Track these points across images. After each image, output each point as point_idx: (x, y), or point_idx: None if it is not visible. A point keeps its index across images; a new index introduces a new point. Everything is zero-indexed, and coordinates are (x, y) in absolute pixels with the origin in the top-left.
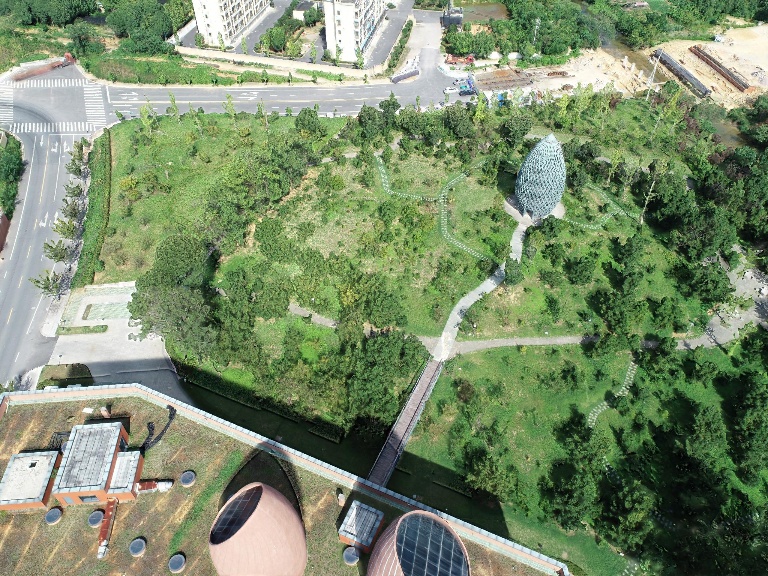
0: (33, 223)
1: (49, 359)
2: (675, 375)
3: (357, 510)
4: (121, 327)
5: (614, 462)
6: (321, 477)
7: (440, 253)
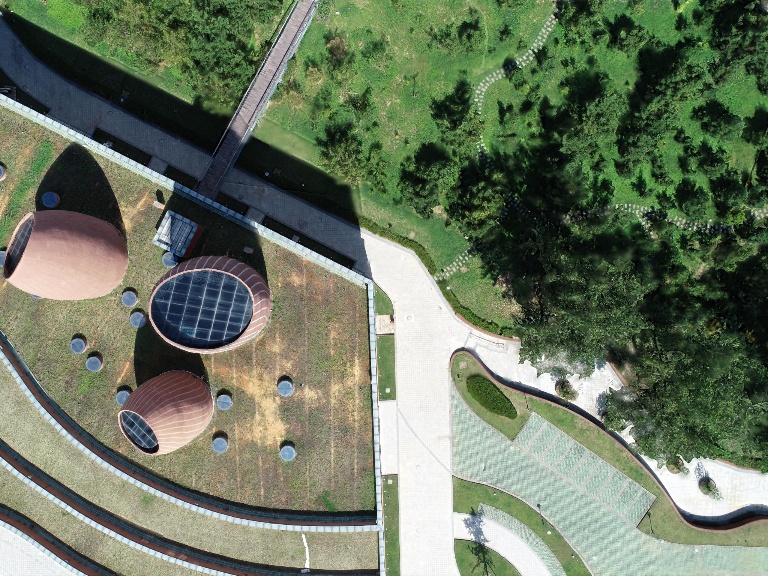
0: None
1: None
2: (596, 39)
3: (172, 219)
4: None
5: (490, 143)
6: (140, 176)
7: None
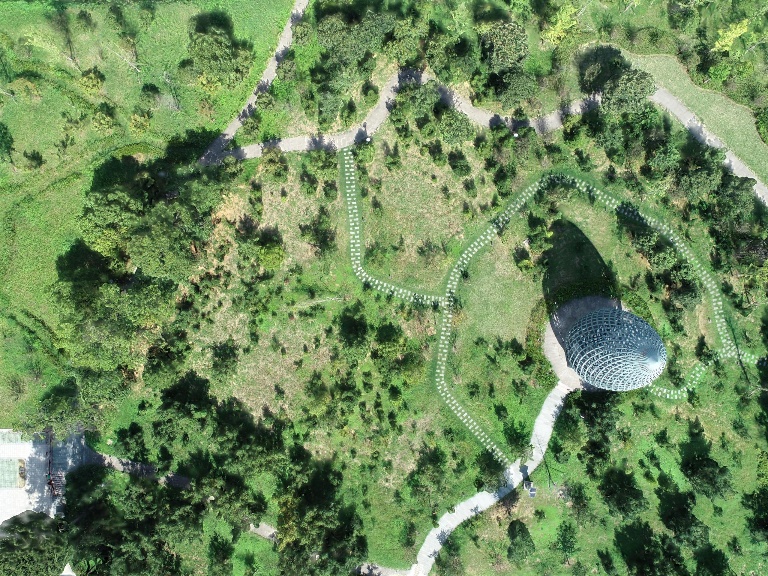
0: None
1: None
2: None
3: None
4: None
5: None
6: None
7: (427, 424)
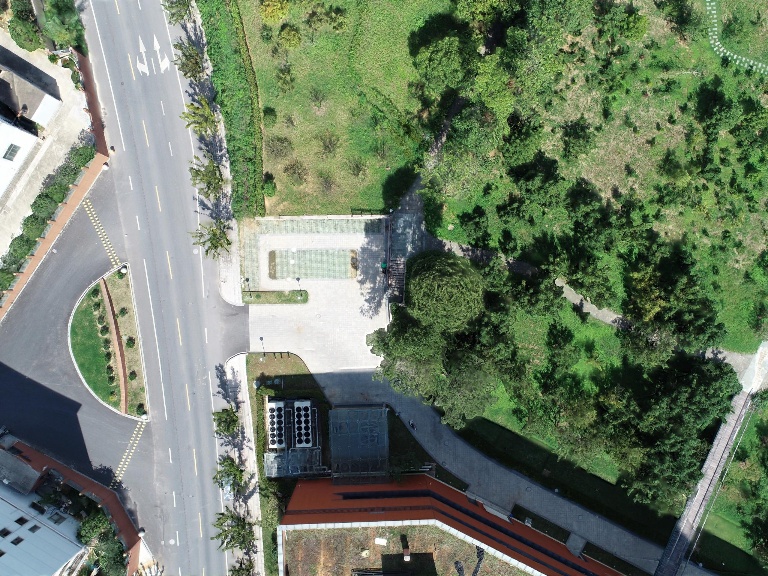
0: (127, 64)
1: (249, 343)
2: None
3: None
4: (326, 295)
5: None
6: None
7: None
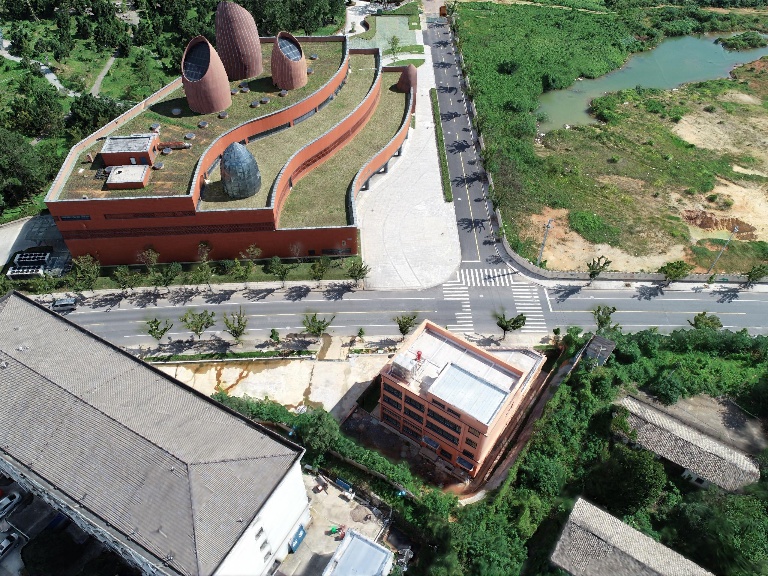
0: None
1: None
2: (153, 37)
3: None
4: None
5: None
6: (174, 92)
7: (2, 90)
